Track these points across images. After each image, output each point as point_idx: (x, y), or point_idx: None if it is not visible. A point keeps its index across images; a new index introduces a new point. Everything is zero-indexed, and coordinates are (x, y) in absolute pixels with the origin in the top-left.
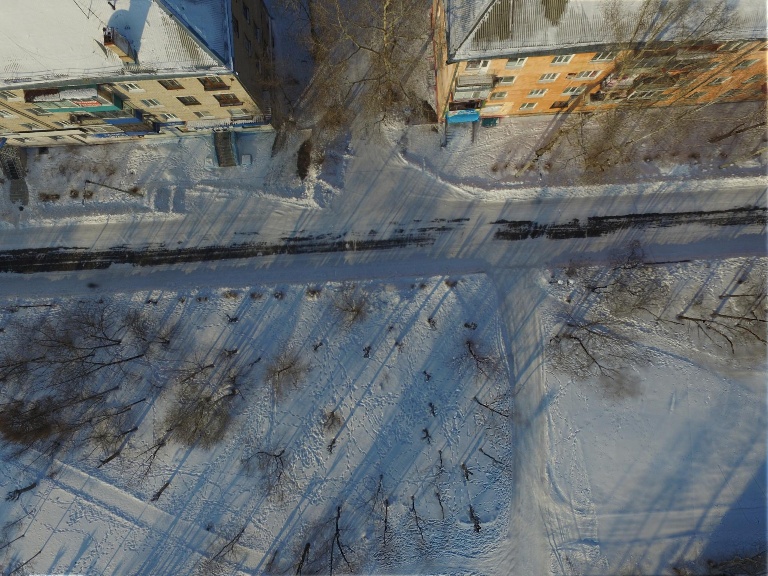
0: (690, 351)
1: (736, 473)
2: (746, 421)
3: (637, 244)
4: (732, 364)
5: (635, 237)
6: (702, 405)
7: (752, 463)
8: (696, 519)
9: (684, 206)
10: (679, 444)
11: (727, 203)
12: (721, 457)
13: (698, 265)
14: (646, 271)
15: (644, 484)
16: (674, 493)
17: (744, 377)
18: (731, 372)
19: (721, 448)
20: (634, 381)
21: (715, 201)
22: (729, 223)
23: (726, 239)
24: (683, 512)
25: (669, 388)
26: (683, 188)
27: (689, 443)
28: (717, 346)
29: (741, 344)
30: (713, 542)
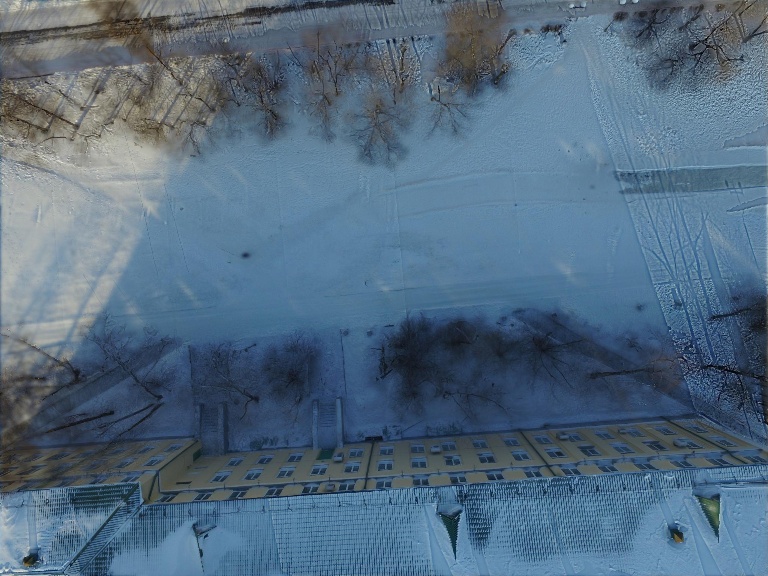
0: (55, 163)
1: (101, 282)
2: (108, 230)
3: (7, 61)
4: (95, 174)
5: (5, 55)
6: (66, 216)
7: (115, 271)
8: (67, 329)
9: (50, 22)
10: (45, 255)
11: (90, 17)
12: (85, 266)
13: (56, 77)
14: (8, 85)
15: (15, 296)
16: (44, 304)
17: (108, 187)
18: (95, 183)
19: (85, 257)
20: (3, 195)
21: (78, 15)
22: (93, 37)
23: (91, 53)
24: (54, 322)
25: (35, 200)
26: (45, 3)
27: (55, 253)
28: (80, 157)
29: (103, 154)
30: (82, 351)
